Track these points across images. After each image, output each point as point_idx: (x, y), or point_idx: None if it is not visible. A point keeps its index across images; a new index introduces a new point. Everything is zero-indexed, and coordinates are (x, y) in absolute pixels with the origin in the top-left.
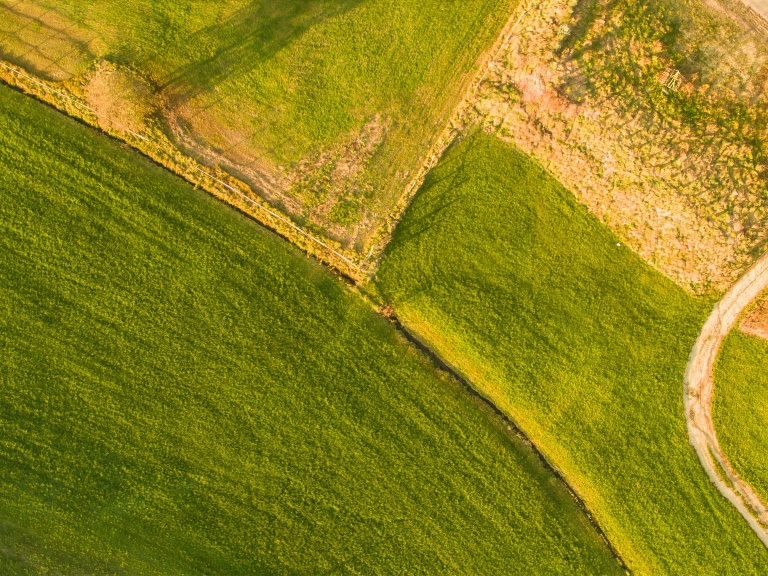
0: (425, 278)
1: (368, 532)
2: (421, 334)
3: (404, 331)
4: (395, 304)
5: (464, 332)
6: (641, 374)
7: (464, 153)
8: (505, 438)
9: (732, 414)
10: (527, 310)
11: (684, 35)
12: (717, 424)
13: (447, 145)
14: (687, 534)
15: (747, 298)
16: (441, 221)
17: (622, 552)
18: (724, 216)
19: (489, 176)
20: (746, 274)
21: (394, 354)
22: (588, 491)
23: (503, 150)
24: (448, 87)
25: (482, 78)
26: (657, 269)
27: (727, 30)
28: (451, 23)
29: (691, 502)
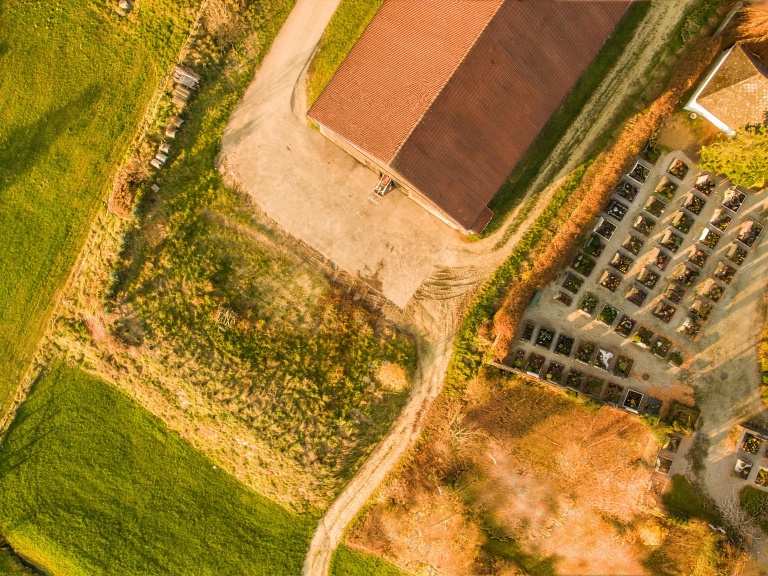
0: (29, 507)
1: None
2: (35, 559)
3: (19, 557)
4: (5, 532)
5: (74, 557)
6: None
7: (52, 386)
8: None
9: None
10: (134, 533)
11: (236, 272)
12: None
13: (32, 381)
14: None
15: (351, 514)
16: (38, 452)
17: None
18: (297, 446)
19: (79, 407)
20: (345, 491)
21: None
22: None
23: (89, 382)
24: (29, 324)
25: (58, 315)
26: (256, 490)
27: (279, 264)
28: (23, 263)
29: None
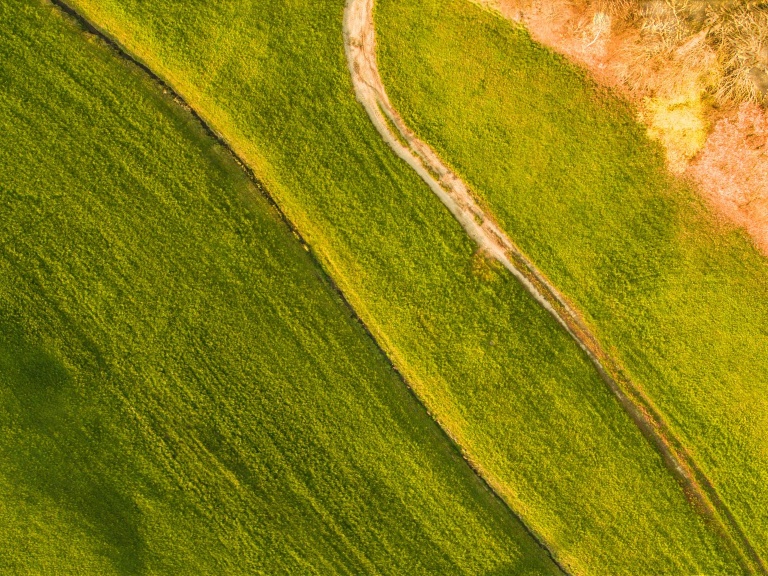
0: None
1: (26, 210)
2: None
3: None
4: None
5: None
6: (296, 24)
7: None
8: (161, 103)
9: (399, 65)
10: None
11: None
12: (384, 77)
13: None
14: (364, 201)
15: None
16: None
17: (298, 225)
18: None
19: None
20: None
21: (37, 16)
22: (255, 158)
23: None
24: None
25: None
26: None
27: None
28: None
29: (365, 165)
